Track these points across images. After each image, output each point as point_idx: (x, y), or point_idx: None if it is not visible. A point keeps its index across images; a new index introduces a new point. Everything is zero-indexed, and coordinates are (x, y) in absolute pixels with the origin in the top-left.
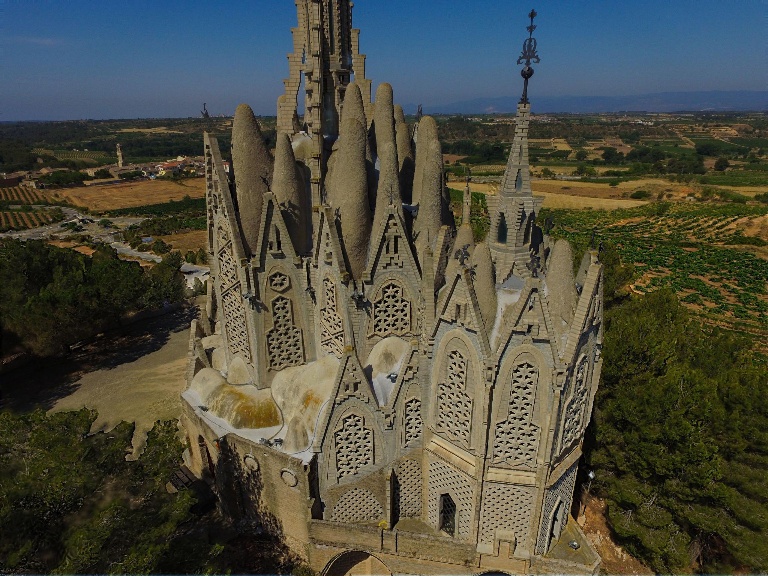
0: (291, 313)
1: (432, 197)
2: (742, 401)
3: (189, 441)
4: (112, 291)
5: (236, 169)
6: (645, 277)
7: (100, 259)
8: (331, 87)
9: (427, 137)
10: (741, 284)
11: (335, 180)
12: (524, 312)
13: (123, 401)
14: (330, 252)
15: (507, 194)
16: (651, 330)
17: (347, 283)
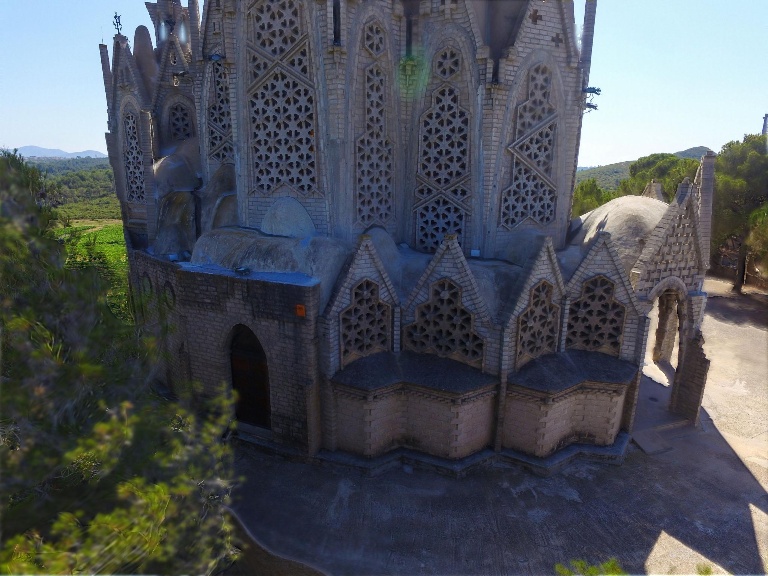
0: None
1: None
2: None
3: None
4: None
5: None
6: None
7: None
8: None
9: None
10: None
11: None
12: None
13: None
14: None
15: None
16: None
17: None
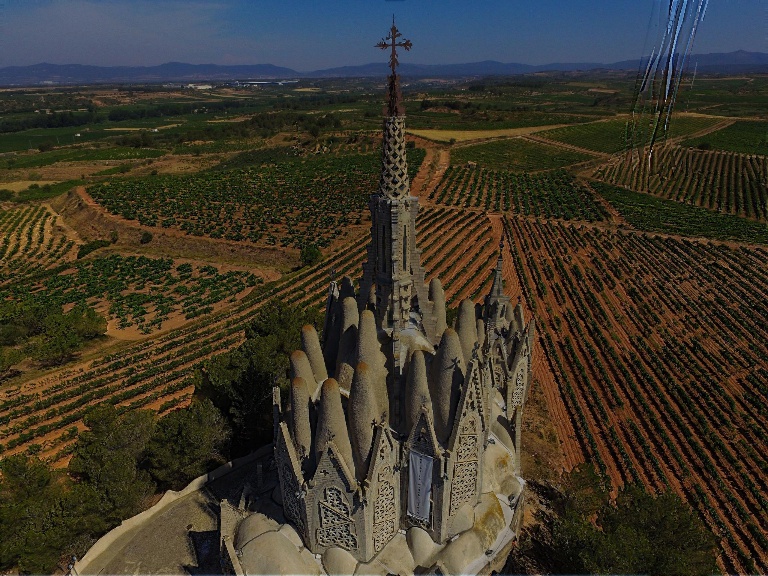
0: None
1: None
2: None
3: None
4: None
5: (464, 375)
6: None
7: None
8: None
9: None
10: (158, 282)
11: None
12: None
13: None
14: None
15: None
16: None
17: None
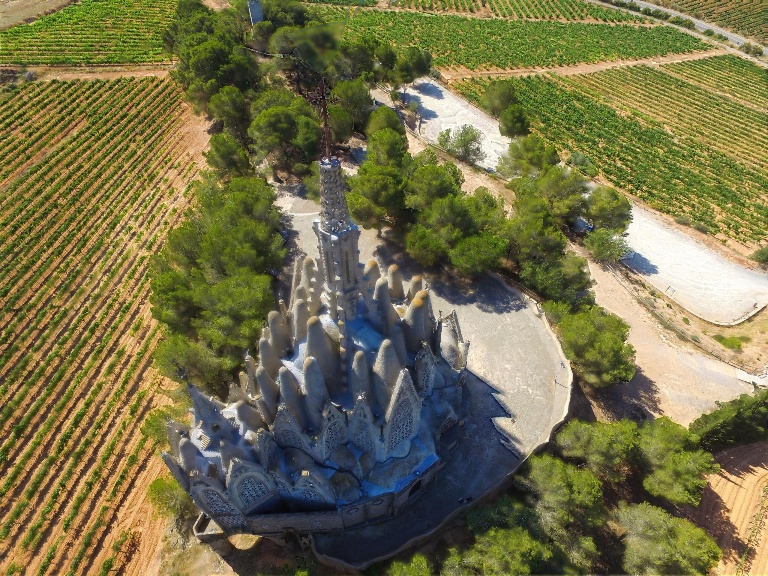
0: None
1: None
2: None
3: None
4: None
5: None
6: None
7: (531, 227)
8: None
9: None
10: None
11: None
12: None
13: None
14: None
15: None
16: None
17: None
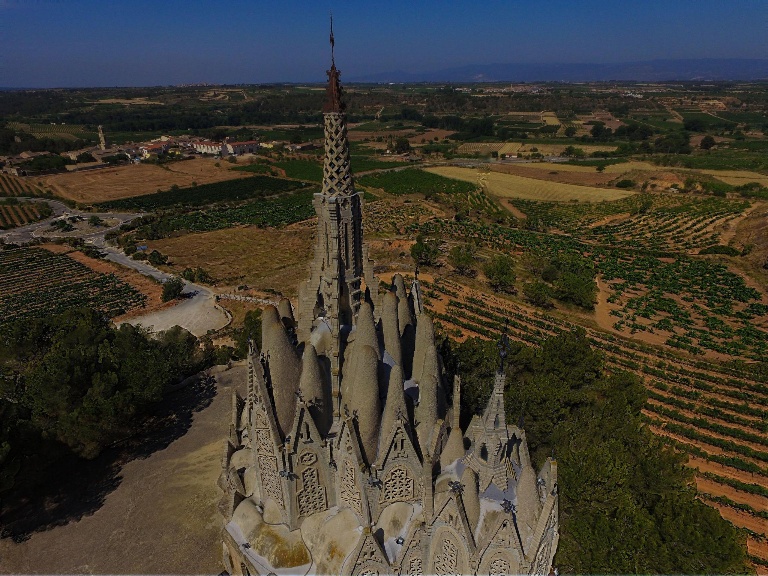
0: (317, 478)
1: (430, 401)
2: (670, 534)
3: (231, 558)
4: (144, 390)
5: (272, 374)
6: (622, 297)
7: (122, 338)
8: (346, 292)
9: (425, 332)
10: (710, 304)
11: (351, 372)
12: (499, 530)
13: (163, 497)
14: (350, 446)
15: (488, 431)
16: (606, 460)
17: (364, 471)
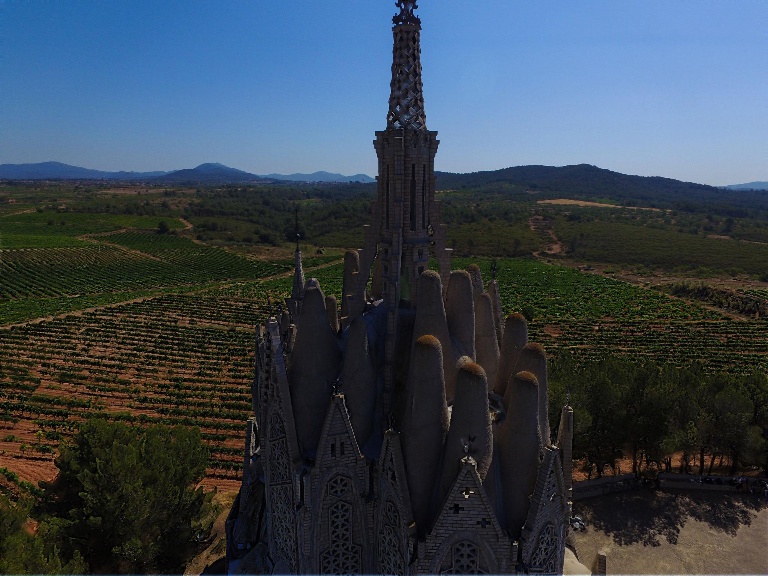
0: None
1: None
2: None
3: None
4: None
5: None
6: None
7: None
8: None
9: None
10: None
11: None
12: None
13: None
14: None
15: None
16: None
17: None
